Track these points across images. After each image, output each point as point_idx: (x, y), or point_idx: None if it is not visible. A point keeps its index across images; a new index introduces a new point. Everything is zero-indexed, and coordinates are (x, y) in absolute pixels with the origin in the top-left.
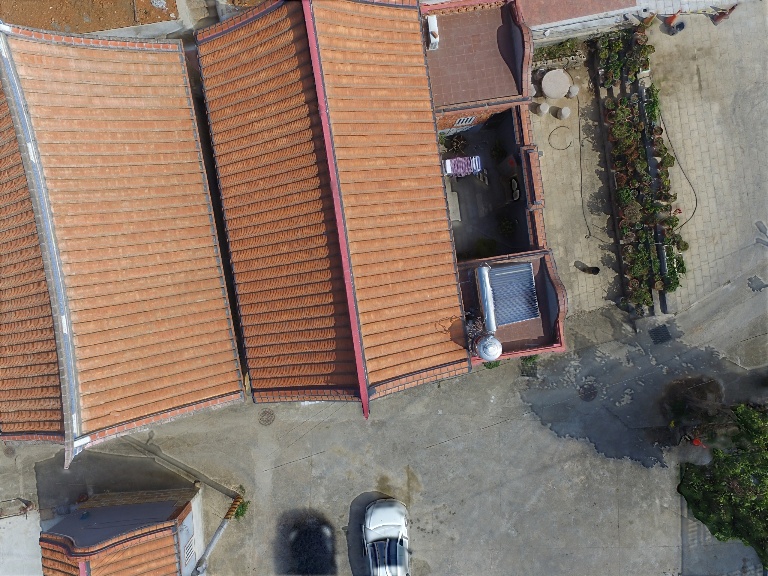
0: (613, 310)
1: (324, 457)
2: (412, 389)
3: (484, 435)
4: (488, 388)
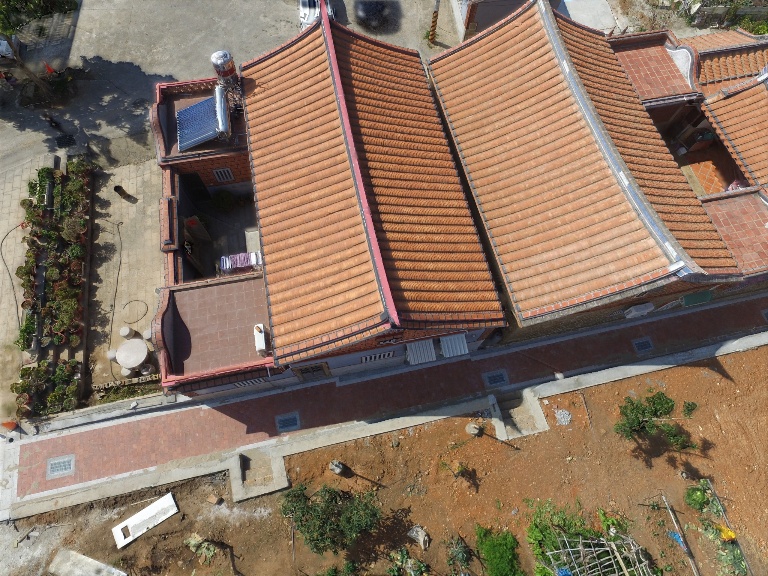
0: (107, 165)
1: None
2: None
3: None
4: None
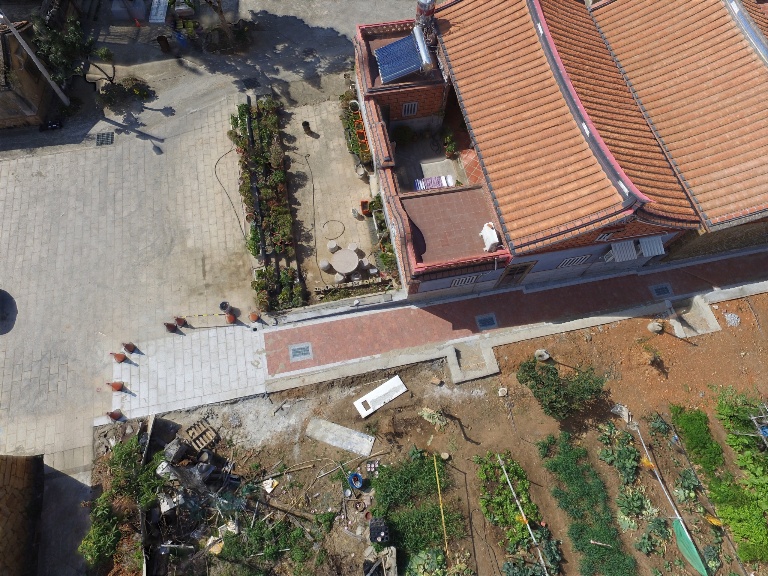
0: (287, 105)
1: None
2: None
3: None
4: None
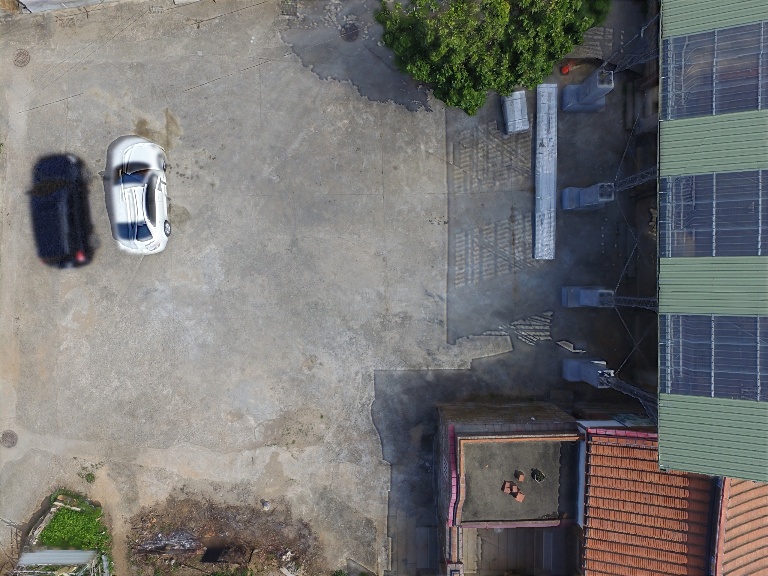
0: None
1: (80, 100)
2: (171, 30)
3: (244, 77)
4: (248, 28)
